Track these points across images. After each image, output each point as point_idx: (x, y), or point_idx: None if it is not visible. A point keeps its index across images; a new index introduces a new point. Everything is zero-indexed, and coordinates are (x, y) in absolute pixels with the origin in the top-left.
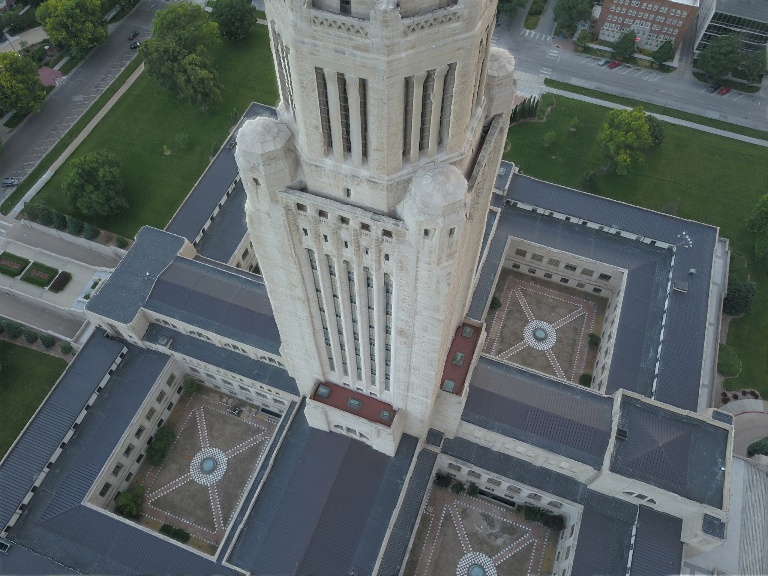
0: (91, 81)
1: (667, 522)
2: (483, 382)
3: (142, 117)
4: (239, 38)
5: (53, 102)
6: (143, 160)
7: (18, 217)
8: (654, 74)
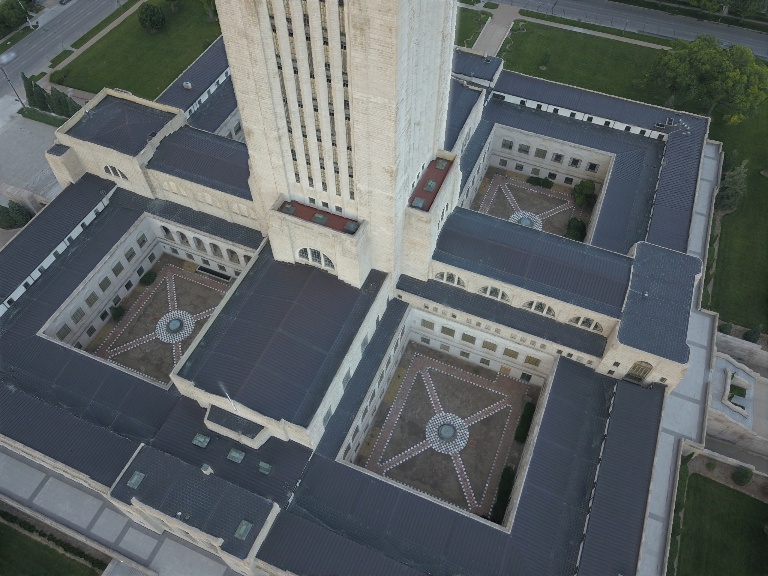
0: None
1: None
2: None
3: None
4: None
5: None
6: None
7: None
8: None
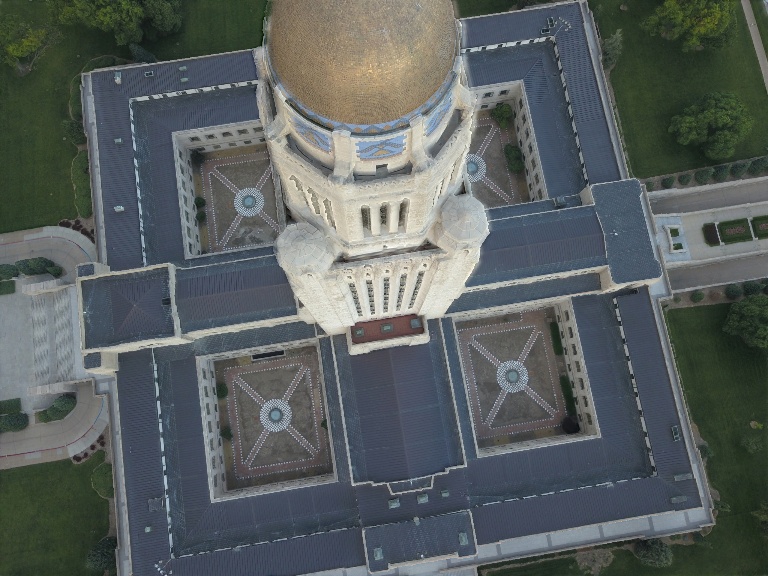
0: None
1: None
2: (288, 290)
3: None
4: None
5: None
6: None
7: None
8: None
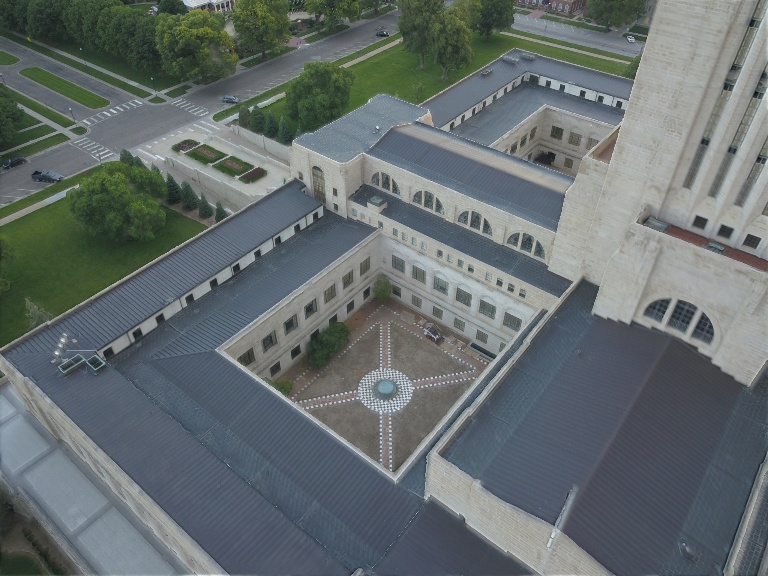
0: (332, 49)
1: None
2: None
3: (376, 76)
4: (491, 35)
5: (291, 57)
6: None
7: (228, 124)
8: None
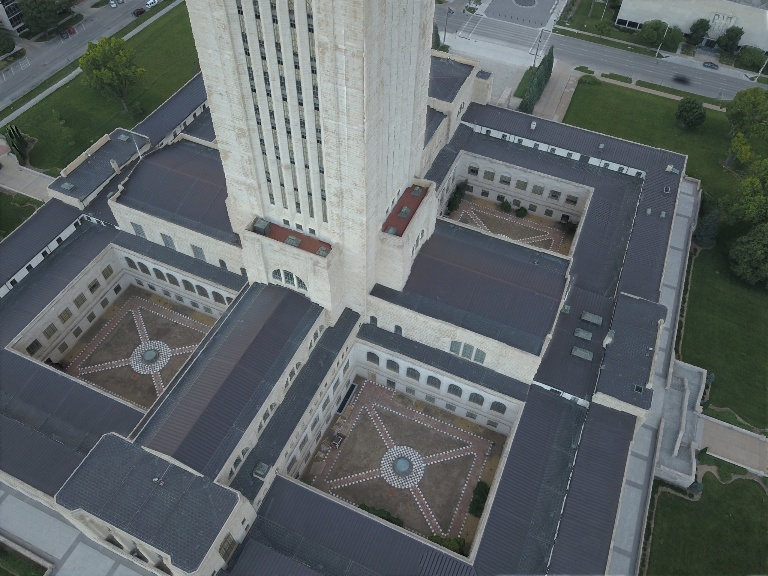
0: None
1: (473, 109)
2: None
3: None
4: None
5: None
6: None
7: None
8: (20, 63)
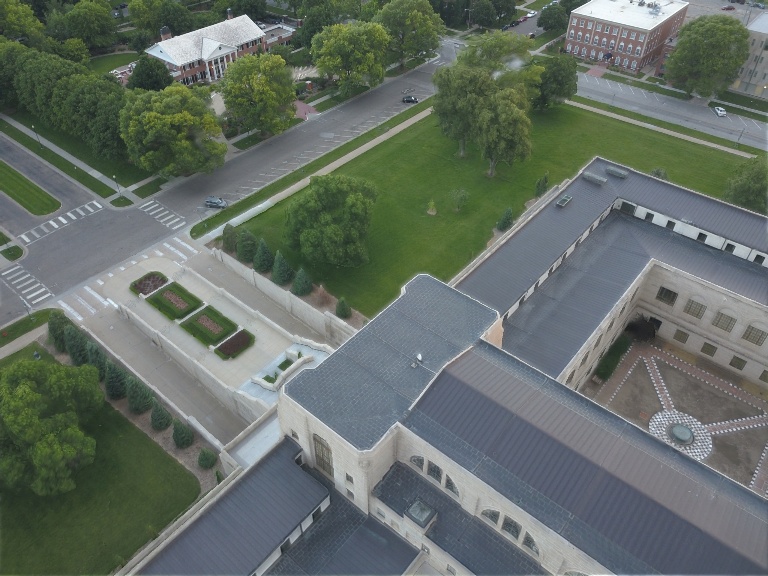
0: (348, 122)
1: None
2: None
3: (404, 167)
4: (547, 108)
5: (297, 134)
6: (396, 214)
7: (209, 244)
8: None
